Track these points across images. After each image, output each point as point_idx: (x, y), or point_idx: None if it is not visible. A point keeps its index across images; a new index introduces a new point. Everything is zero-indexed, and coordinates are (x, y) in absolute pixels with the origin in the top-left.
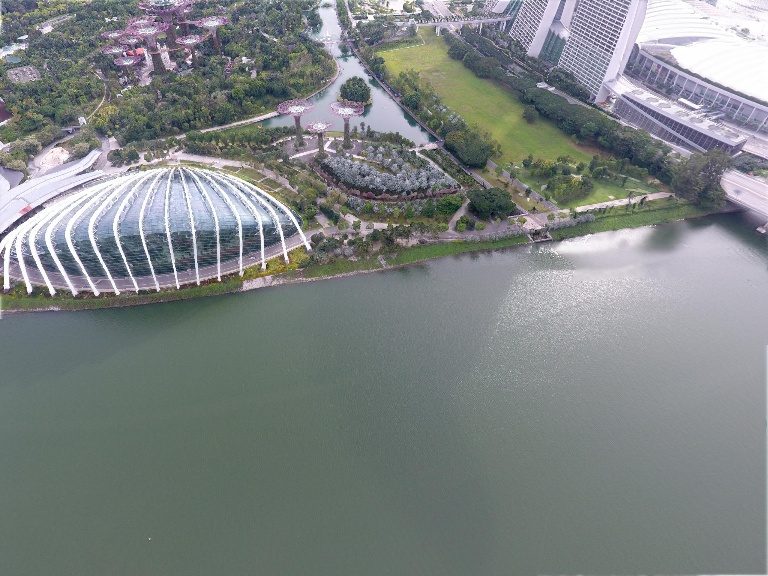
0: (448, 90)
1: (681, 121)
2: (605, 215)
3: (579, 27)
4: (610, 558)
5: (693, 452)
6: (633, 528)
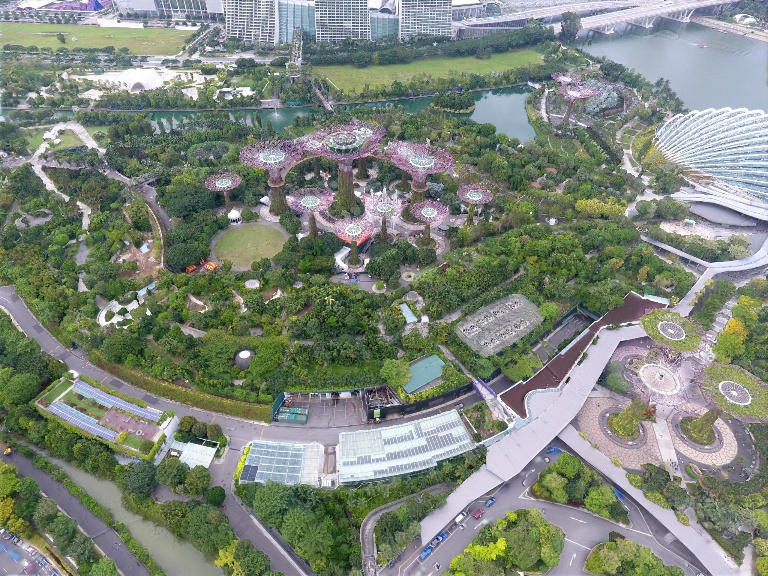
0: (437, 74)
1: (505, 20)
2: None
3: (410, 2)
4: None
5: None
6: (767, 81)
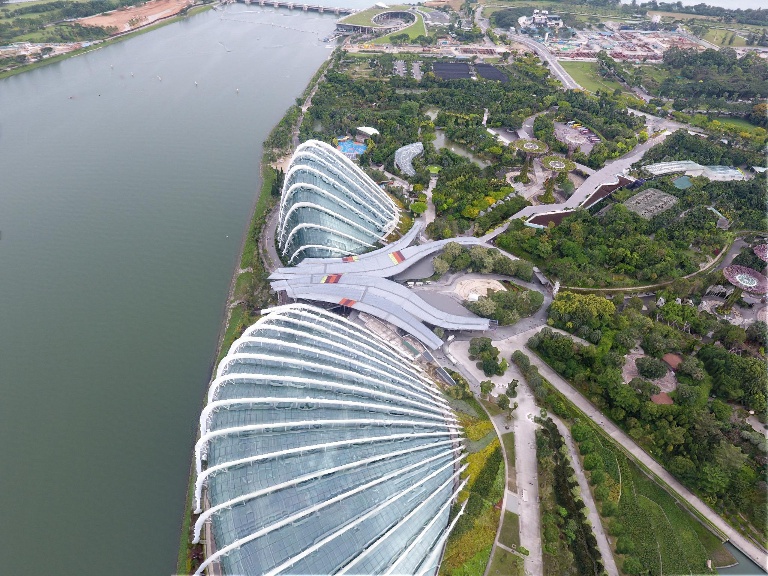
0: None
1: None
2: None
3: None
4: None
5: None
6: None
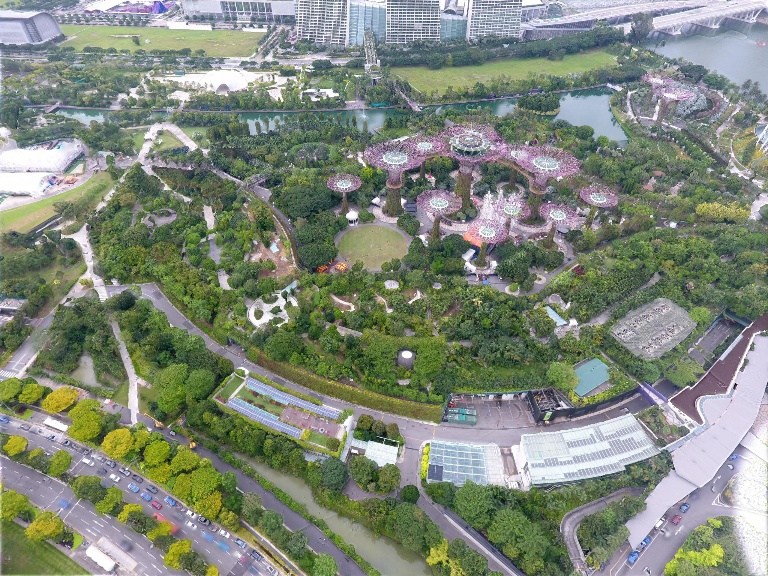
0: (513, 76)
1: (572, 21)
2: None
3: (481, 3)
4: None
5: None
6: None
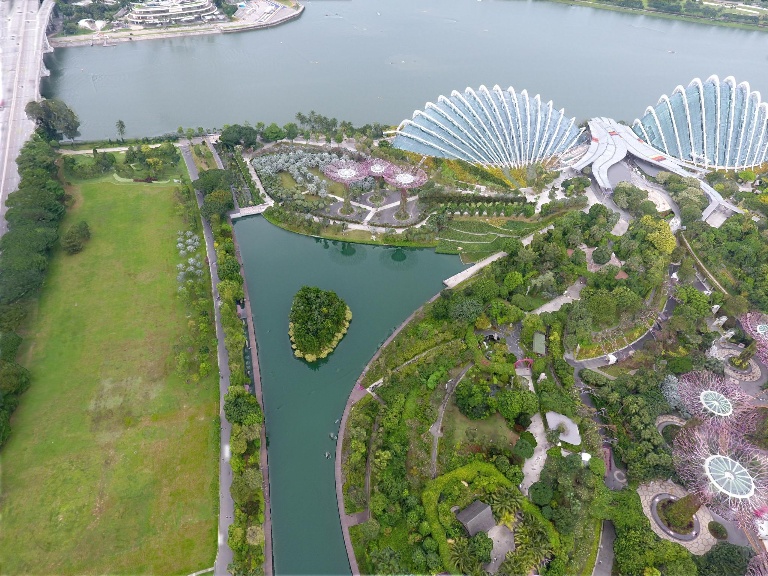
0: (138, 328)
1: None
2: (150, 139)
3: None
4: (284, 68)
5: (231, 77)
6: None
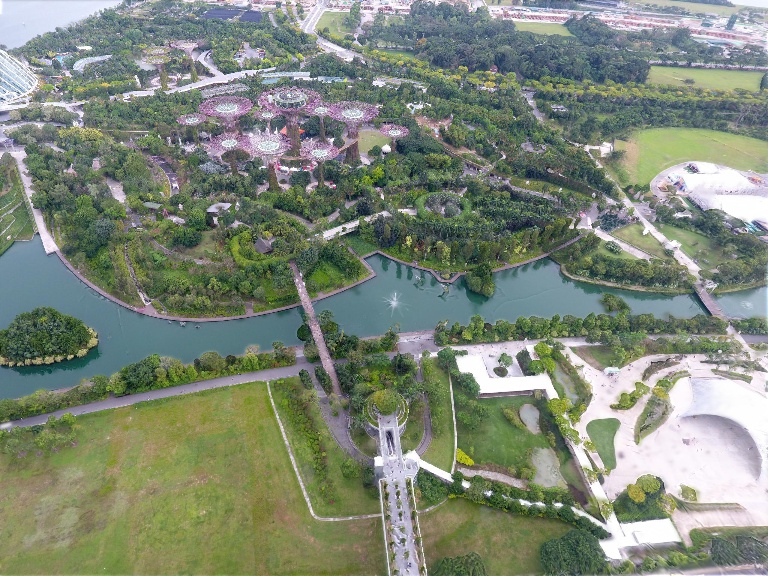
0: None
1: None
2: None
3: None
4: None
5: None
6: None
